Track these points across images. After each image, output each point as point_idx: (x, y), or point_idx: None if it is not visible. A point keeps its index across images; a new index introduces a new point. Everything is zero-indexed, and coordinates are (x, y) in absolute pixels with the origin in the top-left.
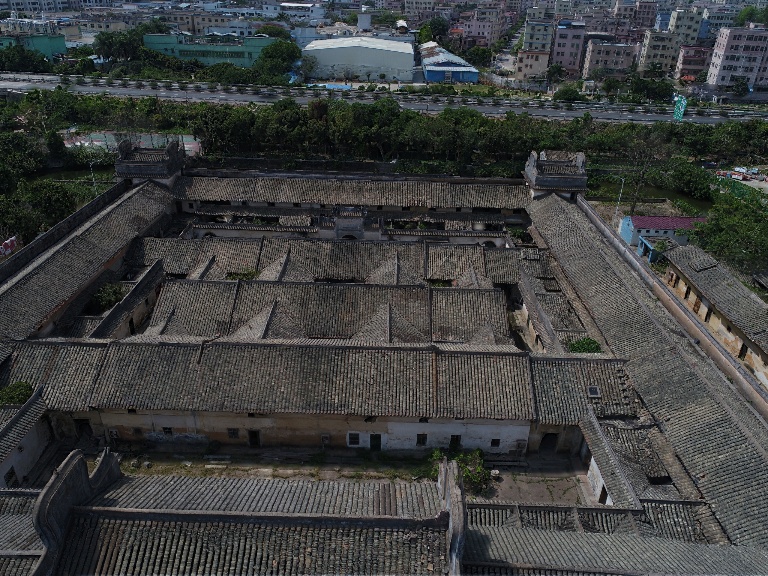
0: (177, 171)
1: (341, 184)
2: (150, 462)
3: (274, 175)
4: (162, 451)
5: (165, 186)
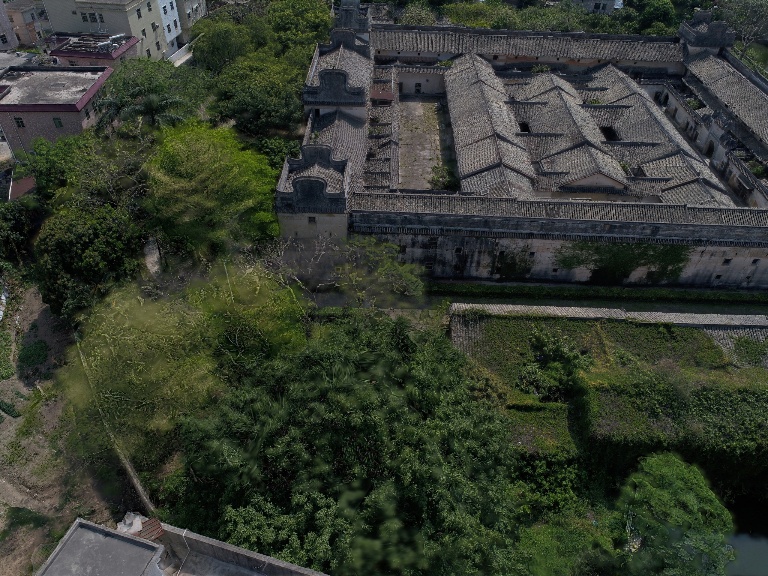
0: (712, 47)
1: (766, 106)
2: (437, 113)
3: (759, 81)
4: (446, 116)
5: (688, 52)
